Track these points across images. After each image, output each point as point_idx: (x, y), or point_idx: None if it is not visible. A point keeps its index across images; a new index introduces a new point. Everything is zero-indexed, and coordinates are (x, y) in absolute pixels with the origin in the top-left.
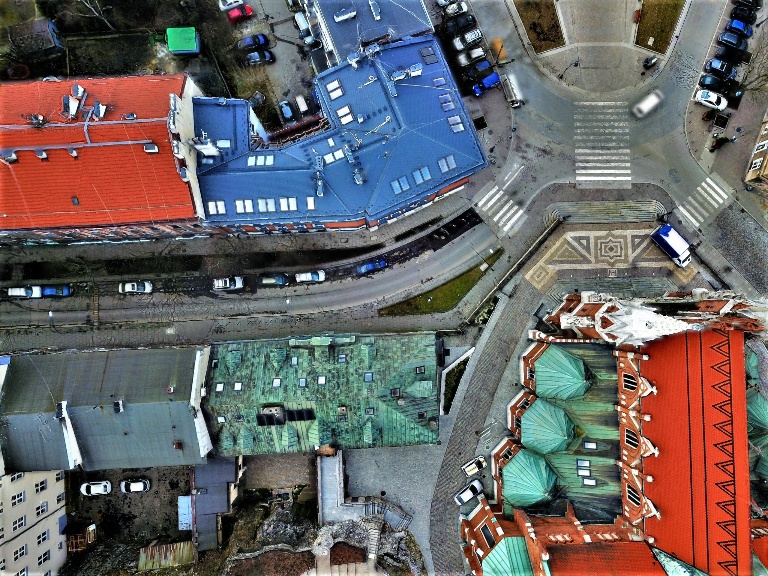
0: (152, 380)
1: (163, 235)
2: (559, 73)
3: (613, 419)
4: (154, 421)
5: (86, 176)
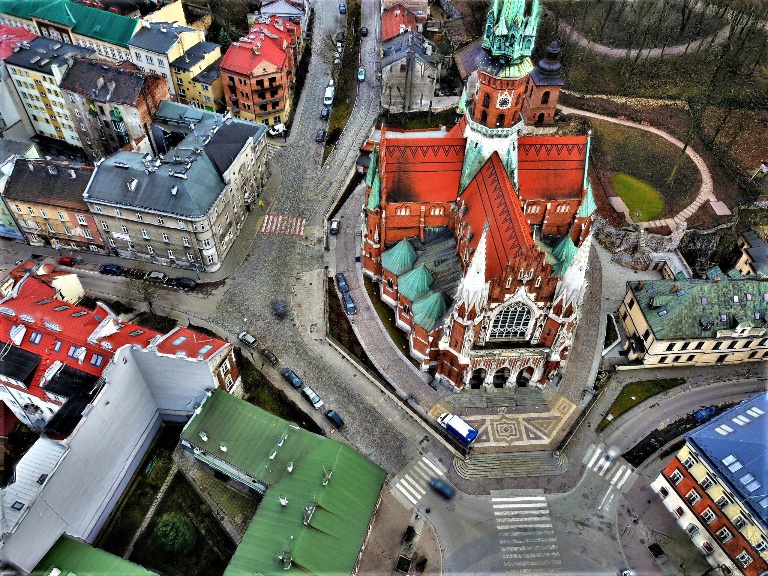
0: None
1: None
2: None
3: None
4: None
5: None
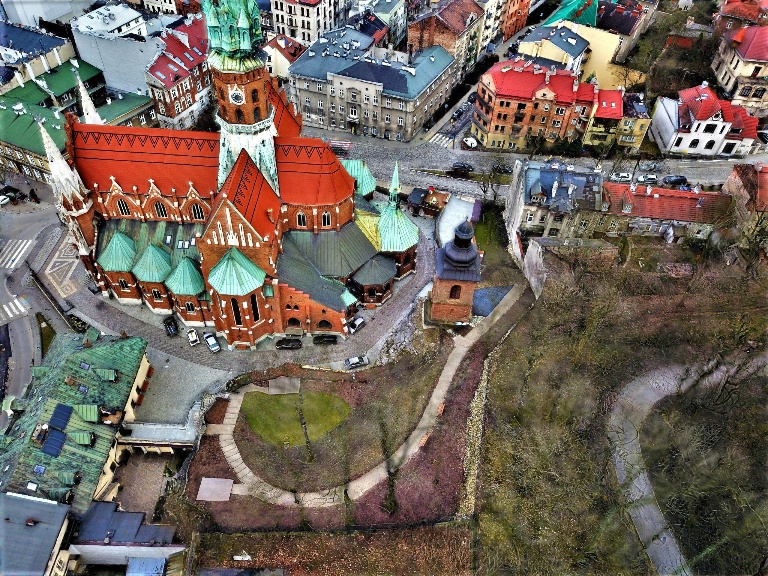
0: None
1: None
2: None
3: (152, 224)
4: None
5: None
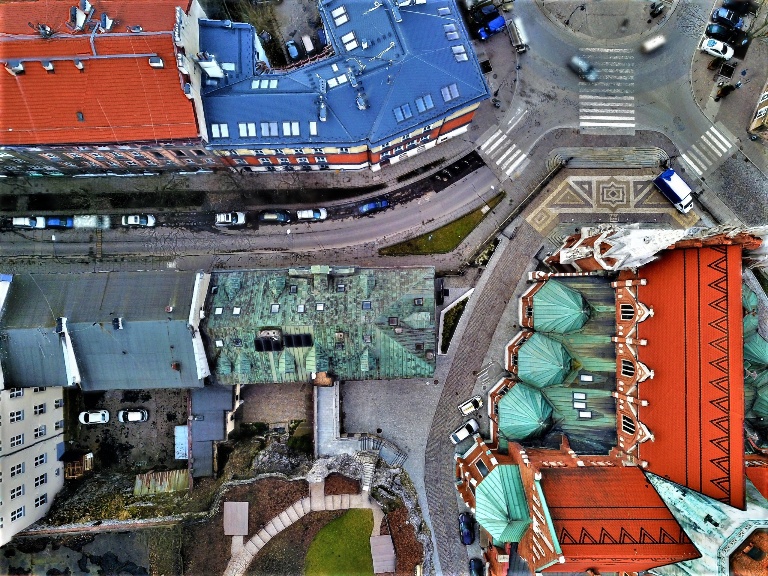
0: (152, 300)
1: (167, 166)
2: (565, 19)
3: (610, 351)
4: (153, 340)
5: (91, 90)
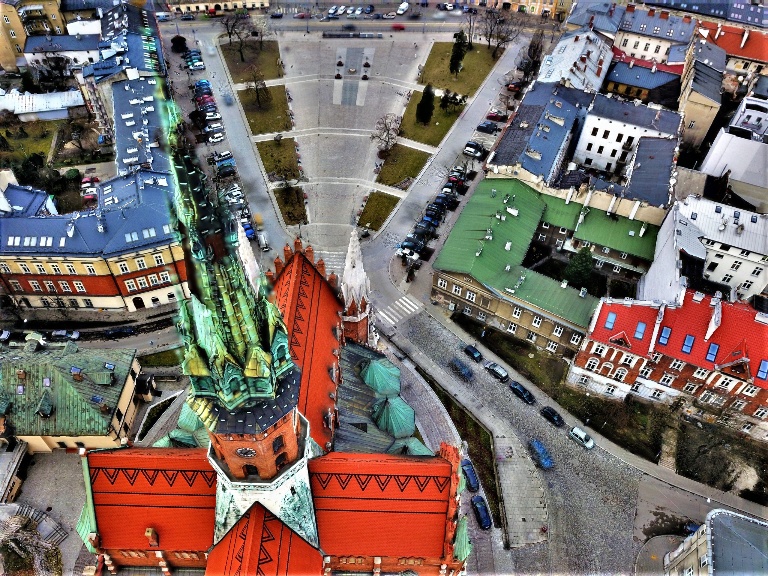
0: None
1: None
2: None
3: None
4: None
5: None
